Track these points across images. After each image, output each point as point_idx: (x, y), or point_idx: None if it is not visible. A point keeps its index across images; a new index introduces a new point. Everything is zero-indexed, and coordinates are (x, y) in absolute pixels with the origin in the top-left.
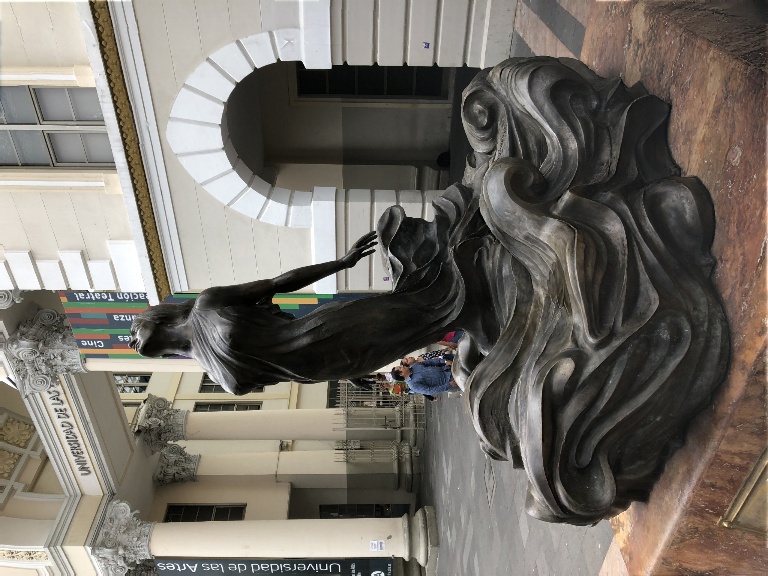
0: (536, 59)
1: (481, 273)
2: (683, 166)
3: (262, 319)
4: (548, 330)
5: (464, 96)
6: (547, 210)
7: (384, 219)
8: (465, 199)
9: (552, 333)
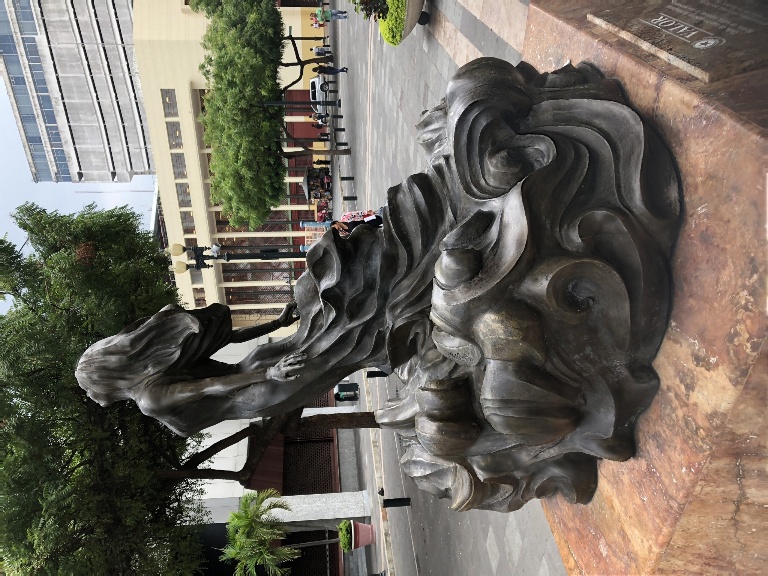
0: (532, 400)
1: (412, 349)
2: (602, 466)
3: (207, 413)
4: (436, 465)
5: (436, 318)
6: (465, 457)
7: (315, 254)
8: (424, 246)
9: (437, 471)
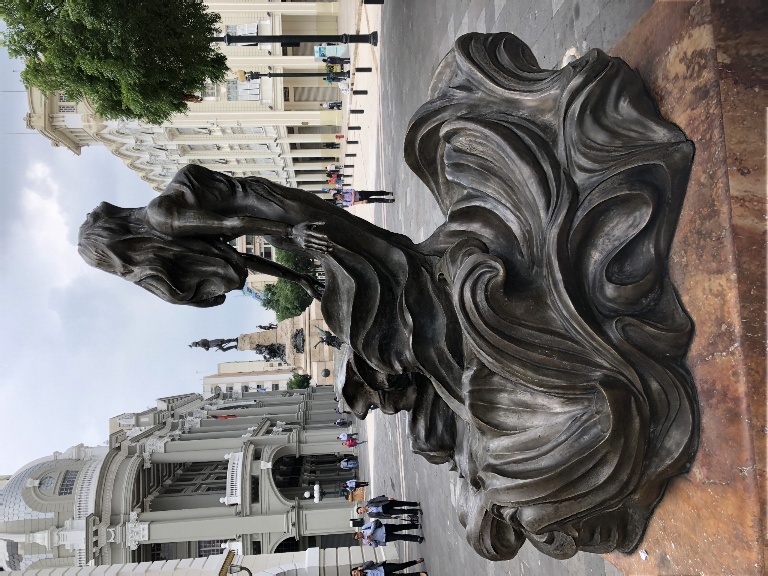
0: None
1: None
2: None
3: None
4: None
5: None
6: None
7: None
8: None
9: None
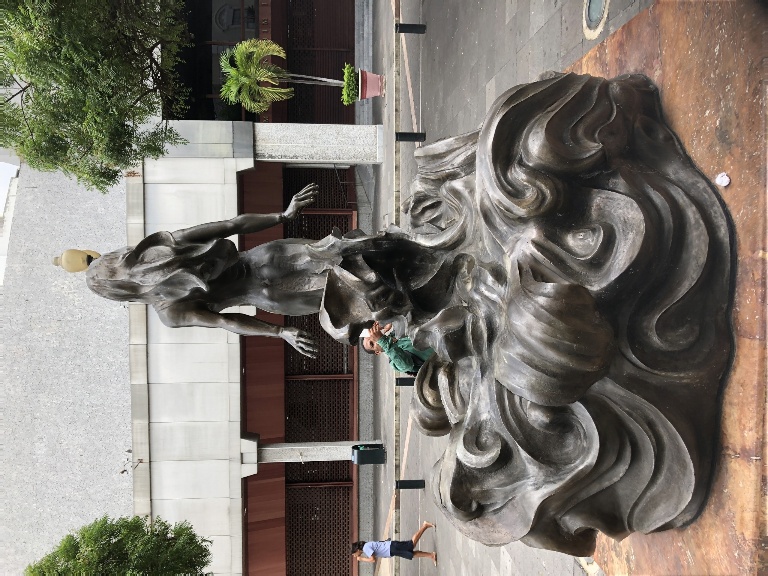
0: None
1: None
2: None
3: None
4: None
5: None
6: None
7: None
8: None
9: None
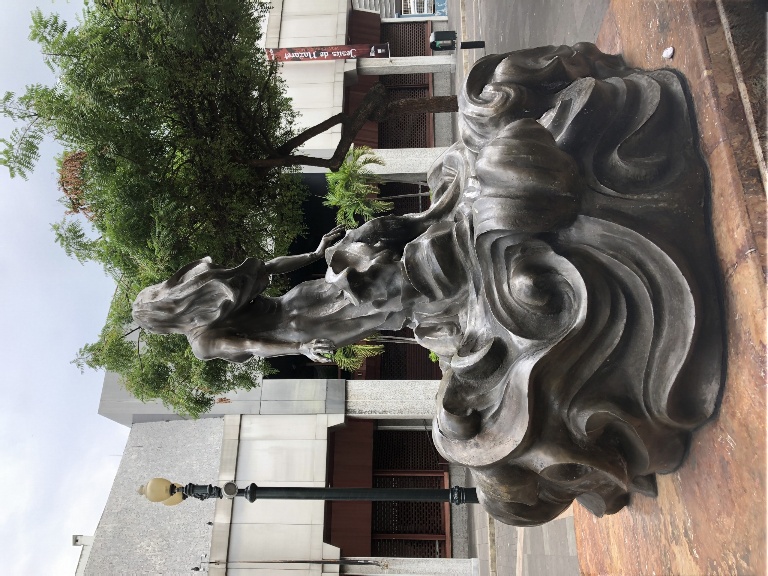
0: None
1: None
2: None
3: None
4: None
5: None
6: None
7: None
8: (446, 296)
9: None
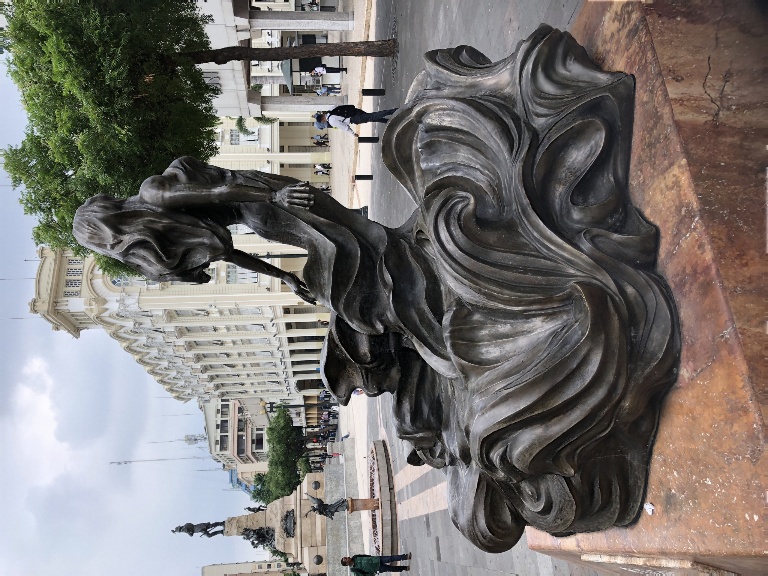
0: None
1: None
2: None
3: None
4: None
5: None
6: None
7: None
8: None
9: None
